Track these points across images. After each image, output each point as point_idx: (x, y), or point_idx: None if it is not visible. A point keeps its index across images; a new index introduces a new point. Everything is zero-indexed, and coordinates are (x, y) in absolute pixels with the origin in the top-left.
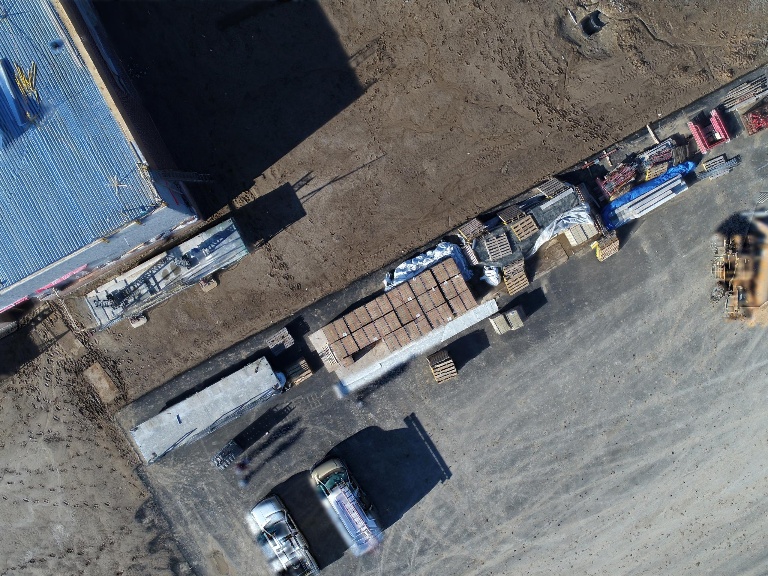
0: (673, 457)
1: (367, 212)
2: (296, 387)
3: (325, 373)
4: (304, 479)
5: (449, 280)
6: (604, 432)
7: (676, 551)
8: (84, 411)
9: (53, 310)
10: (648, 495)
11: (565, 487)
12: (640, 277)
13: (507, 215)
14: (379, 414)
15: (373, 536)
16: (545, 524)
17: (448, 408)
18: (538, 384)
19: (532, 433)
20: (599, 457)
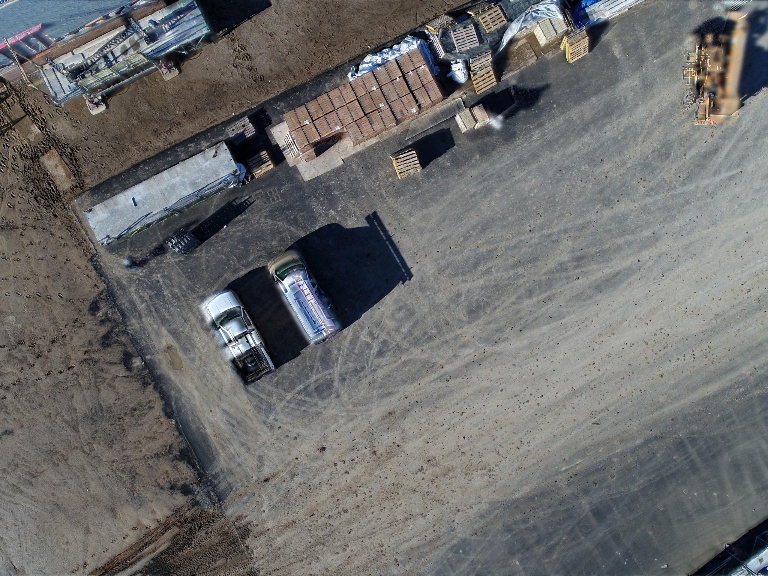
0: (639, 265)
1: (334, 5)
2: (256, 181)
3: (286, 167)
4: (262, 275)
5: (414, 70)
6: (569, 237)
7: (639, 361)
8: (39, 199)
9: (10, 93)
10: (612, 303)
11: (528, 292)
12: (610, 81)
13: (475, 8)
14: (340, 211)
15: (331, 336)
16: (507, 329)
17: (411, 208)
18: (503, 186)
19: (496, 236)
20: (563, 263)
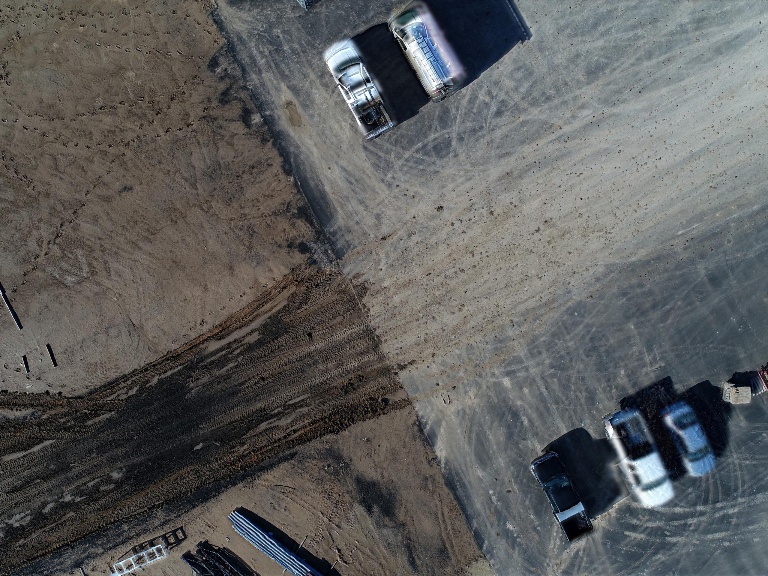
0: (760, 27)
1: None
2: None
3: None
4: (381, 32)
5: None
6: None
7: (759, 125)
8: None
9: None
10: (733, 65)
11: (648, 53)
12: None
13: None
14: None
15: (449, 94)
16: (626, 90)
17: None
18: None
19: None
20: (684, 24)
